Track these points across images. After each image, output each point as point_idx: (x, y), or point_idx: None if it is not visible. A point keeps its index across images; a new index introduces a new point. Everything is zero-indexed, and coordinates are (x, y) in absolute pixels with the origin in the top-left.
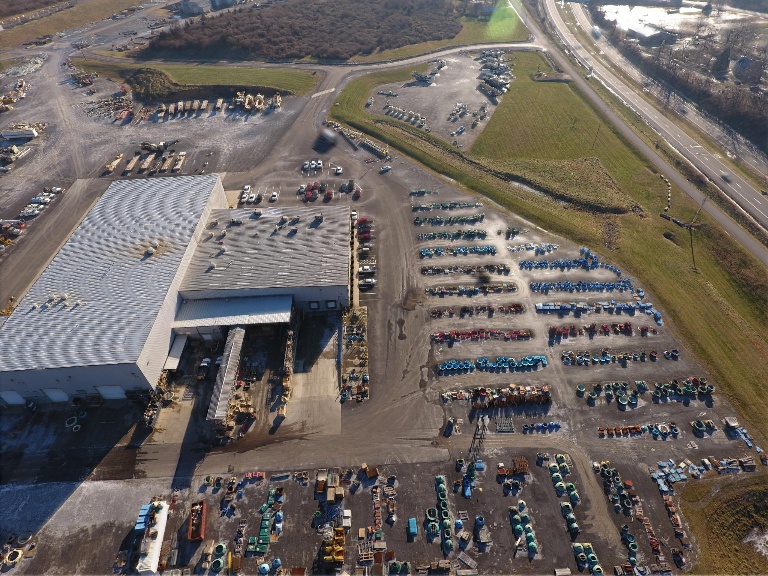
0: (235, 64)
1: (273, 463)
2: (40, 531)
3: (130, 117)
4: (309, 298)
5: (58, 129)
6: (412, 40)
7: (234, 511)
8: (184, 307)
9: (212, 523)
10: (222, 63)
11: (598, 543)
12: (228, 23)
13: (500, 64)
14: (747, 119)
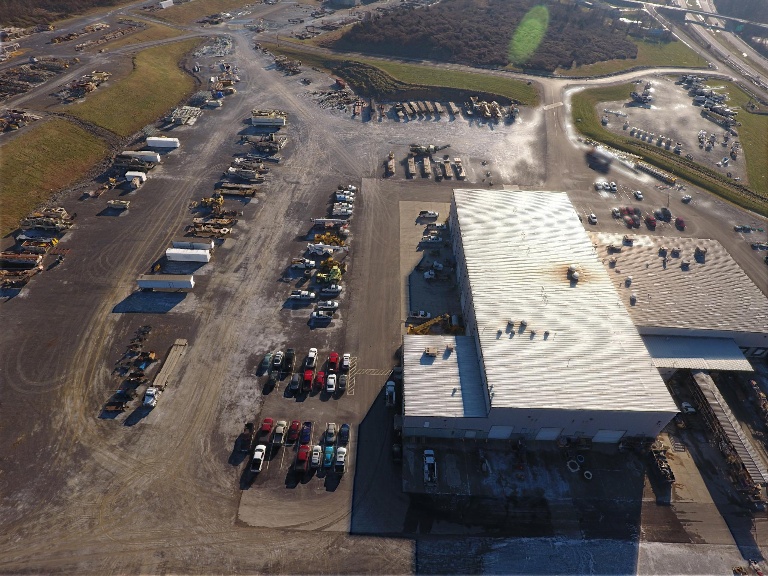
0: (442, 65)
1: None
2: None
3: (367, 113)
4: (743, 343)
5: (300, 119)
6: (602, 57)
7: None
8: None
9: None
10: (427, 63)
11: None
12: (418, 21)
13: (713, 92)
14: None
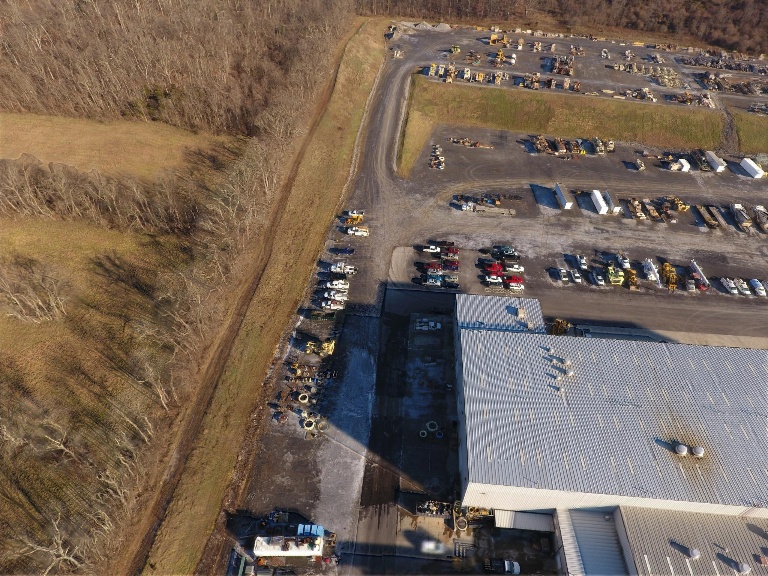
0: None
1: None
2: (326, 436)
3: None
4: None
5: None
6: None
7: None
8: (598, 518)
9: None
10: None
11: None
12: None
13: None
14: None
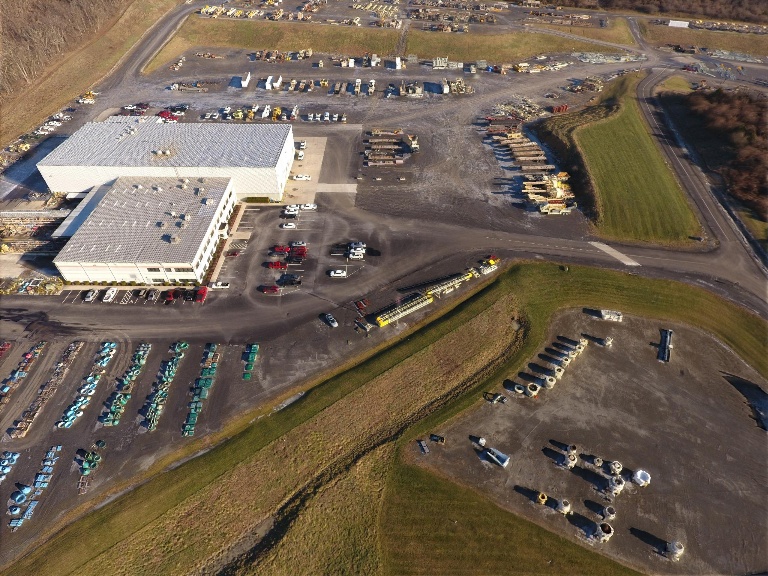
0: (679, 161)
1: None
2: (0, 180)
3: None
4: None
5: (463, 99)
6: None
7: None
8: None
9: None
10: (676, 151)
11: None
12: None
13: None
14: None
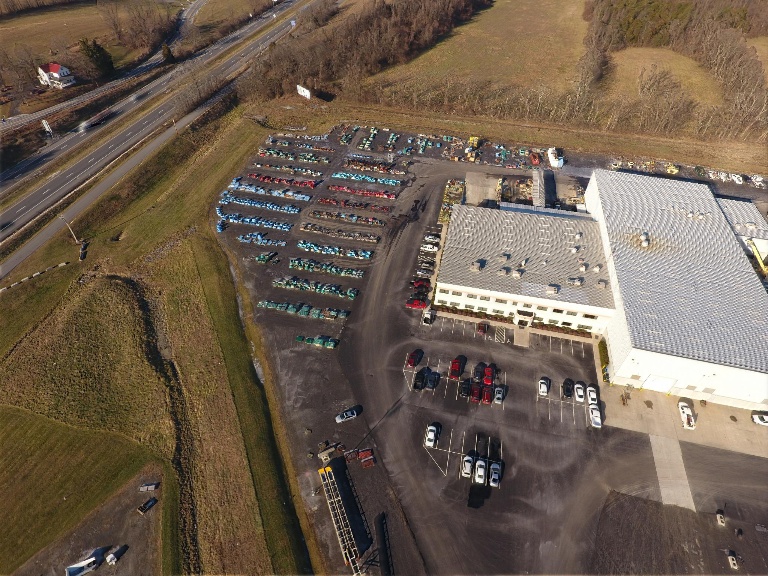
0: None
1: (503, 169)
2: None
3: None
4: None
5: None
6: None
7: None
8: None
9: None
10: None
11: None
12: None
13: None
14: None
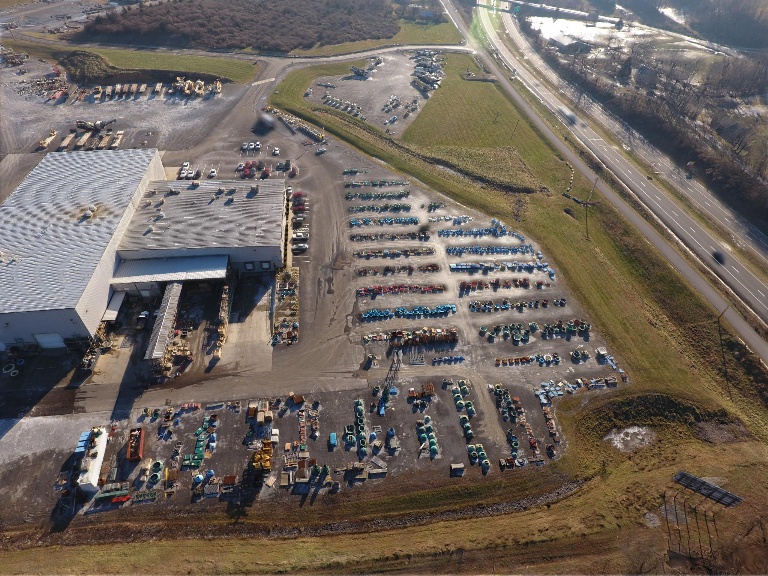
0: (175, 51)
1: (208, 396)
2: None
3: (64, 97)
4: (244, 259)
5: None
6: (351, 37)
7: (171, 435)
8: (122, 266)
9: (150, 446)
10: (161, 50)
11: (488, 444)
12: (168, 11)
13: (433, 63)
14: (641, 117)
